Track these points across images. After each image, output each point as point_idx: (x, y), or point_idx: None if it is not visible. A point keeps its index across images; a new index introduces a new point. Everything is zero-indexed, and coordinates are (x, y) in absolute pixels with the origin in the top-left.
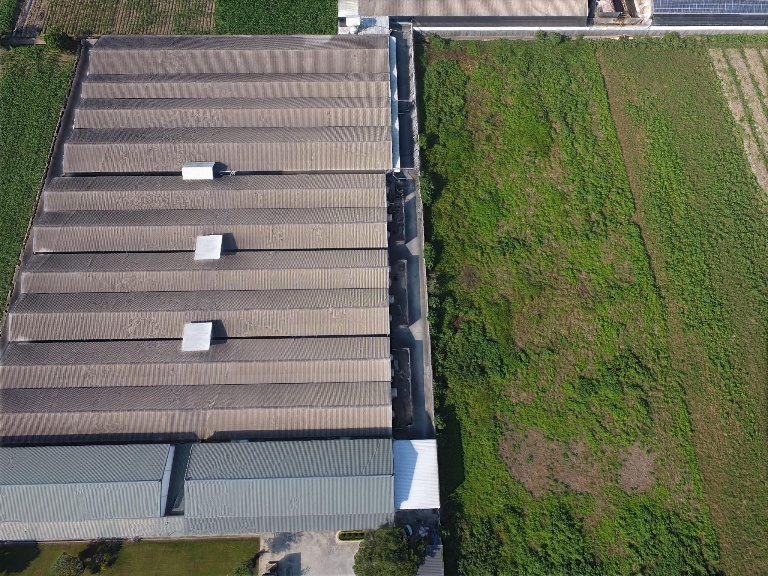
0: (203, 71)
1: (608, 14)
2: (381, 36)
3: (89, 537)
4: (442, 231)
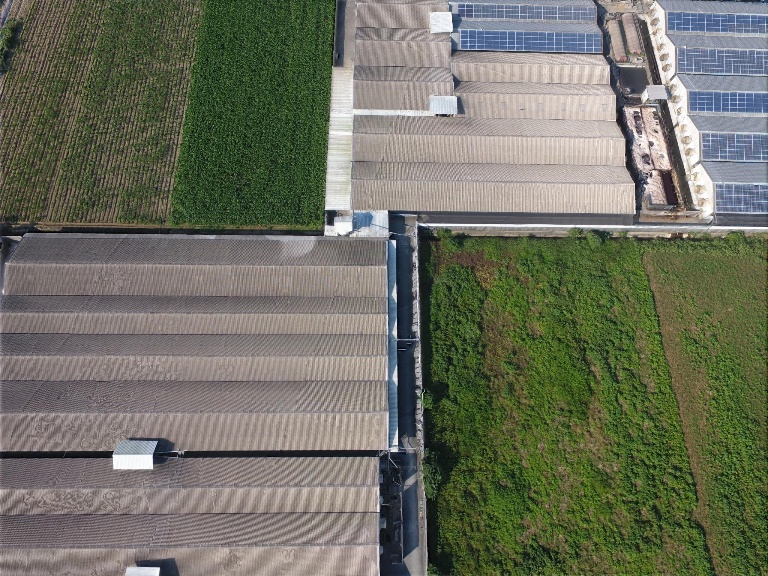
0: (151, 292)
1: (658, 206)
2: (378, 240)
3: None
4: (451, 537)
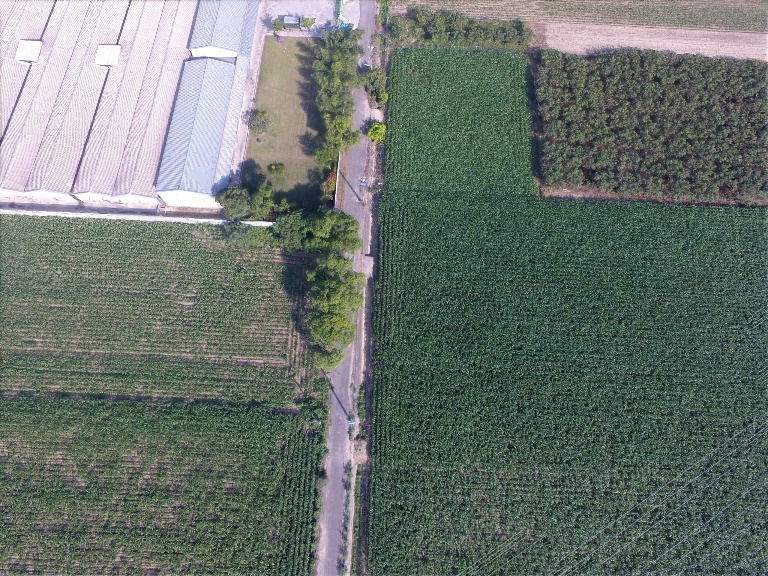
0: None
1: None
2: None
3: (240, 110)
4: None
